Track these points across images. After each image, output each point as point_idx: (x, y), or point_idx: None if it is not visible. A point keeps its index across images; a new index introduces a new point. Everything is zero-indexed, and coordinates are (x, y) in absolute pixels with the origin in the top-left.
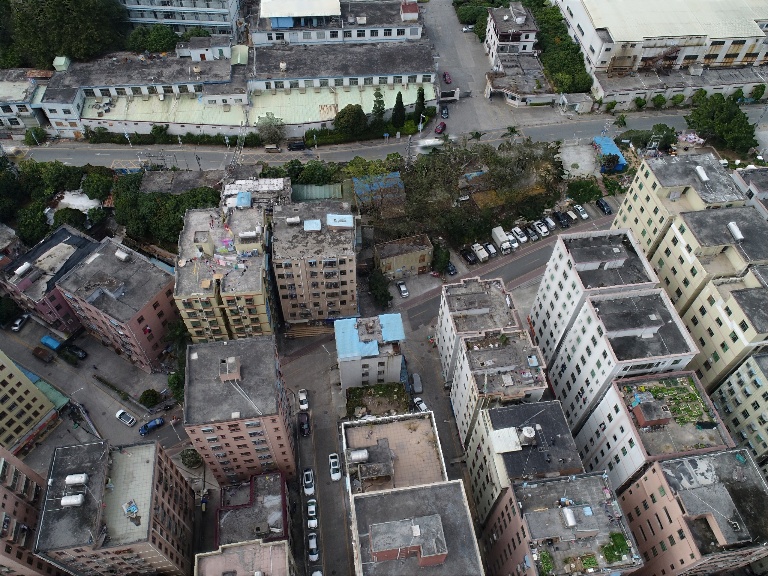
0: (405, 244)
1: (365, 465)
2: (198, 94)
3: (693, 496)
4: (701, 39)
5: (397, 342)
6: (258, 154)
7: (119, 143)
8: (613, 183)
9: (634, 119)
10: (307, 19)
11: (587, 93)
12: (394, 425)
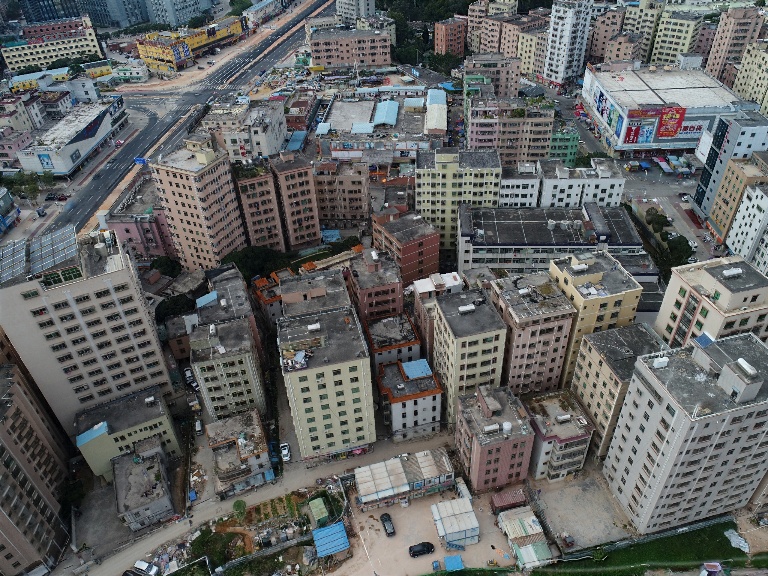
0: None
1: None
2: (682, 3)
3: None
4: None
5: None
6: None
7: None
8: None
9: None
10: None
11: None
12: None
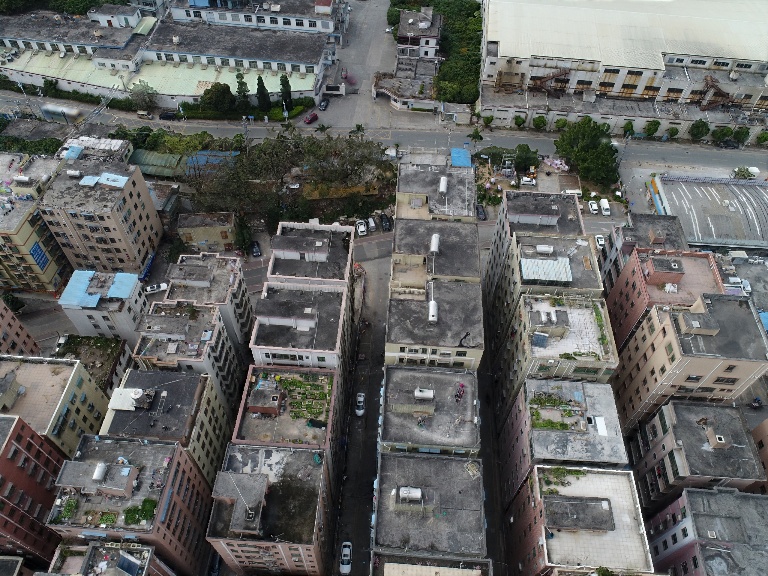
0: (209, 218)
1: None
2: None
3: (230, 480)
4: (595, 65)
5: (126, 301)
6: (130, 118)
7: (17, 91)
8: None
9: (511, 137)
10: (221, 0)
11: (469, 105)
12: (42, 366)
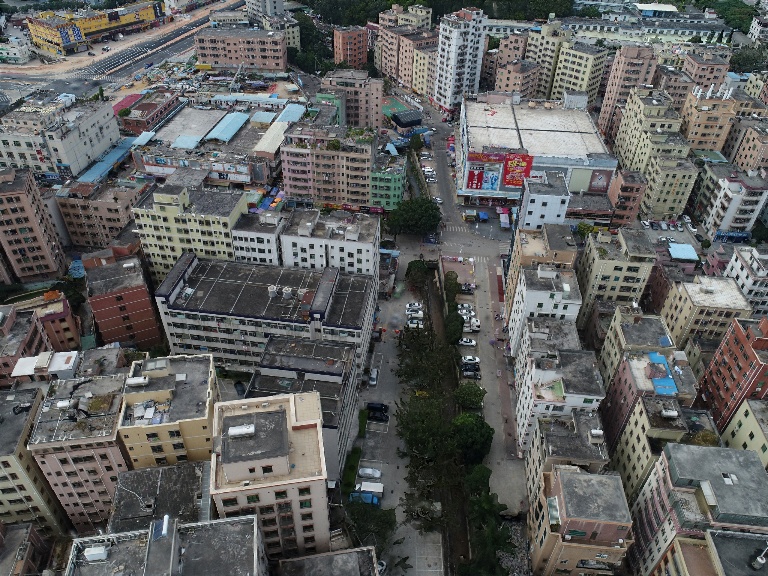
0: None
1: (767, 74)
2: (615, 32)
3: None
4: None
5: None
6: None
7: None
8: None
9: None
10: (660, 12)
11: None
12: None
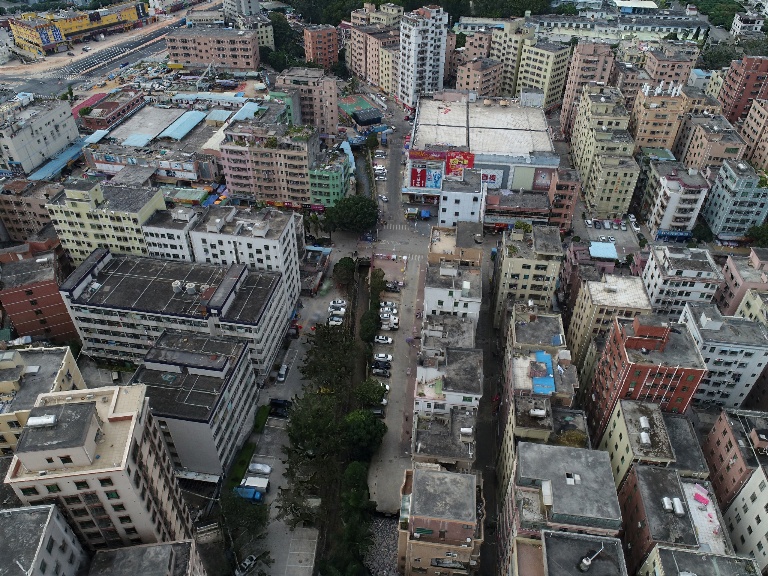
0: None
1: None
2: (591, 29)
3: None
4: None
5: None
6: None
7: None
8: None
9: None
10: (640, 9)
11: None
12: None
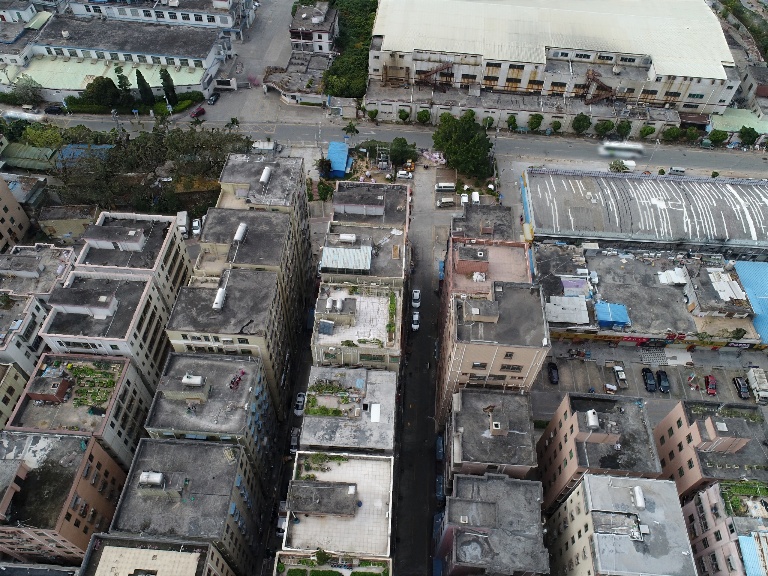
0: (72, 211)
1: None
2: None
3: None
4: (478, 59)
5: None
6: (16, 112)
7: None
8: (328, 189)
9: (396, 131)
10: None
11: (355, 99)
12: None
